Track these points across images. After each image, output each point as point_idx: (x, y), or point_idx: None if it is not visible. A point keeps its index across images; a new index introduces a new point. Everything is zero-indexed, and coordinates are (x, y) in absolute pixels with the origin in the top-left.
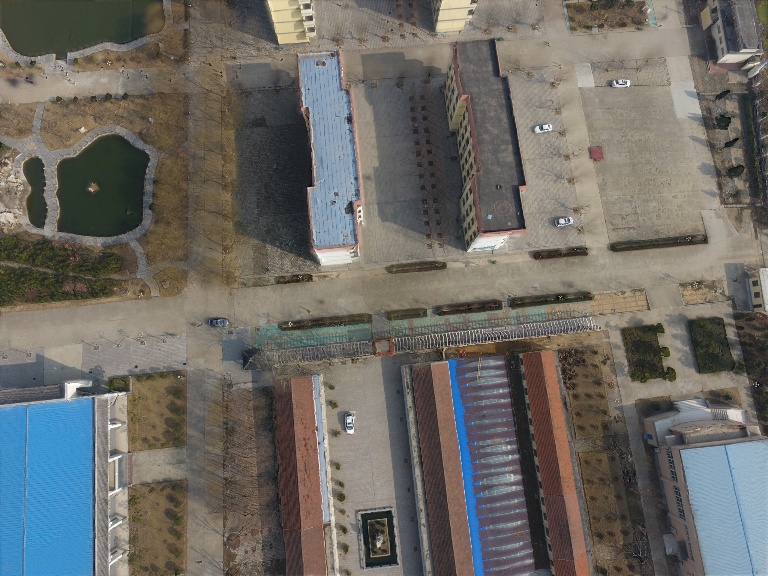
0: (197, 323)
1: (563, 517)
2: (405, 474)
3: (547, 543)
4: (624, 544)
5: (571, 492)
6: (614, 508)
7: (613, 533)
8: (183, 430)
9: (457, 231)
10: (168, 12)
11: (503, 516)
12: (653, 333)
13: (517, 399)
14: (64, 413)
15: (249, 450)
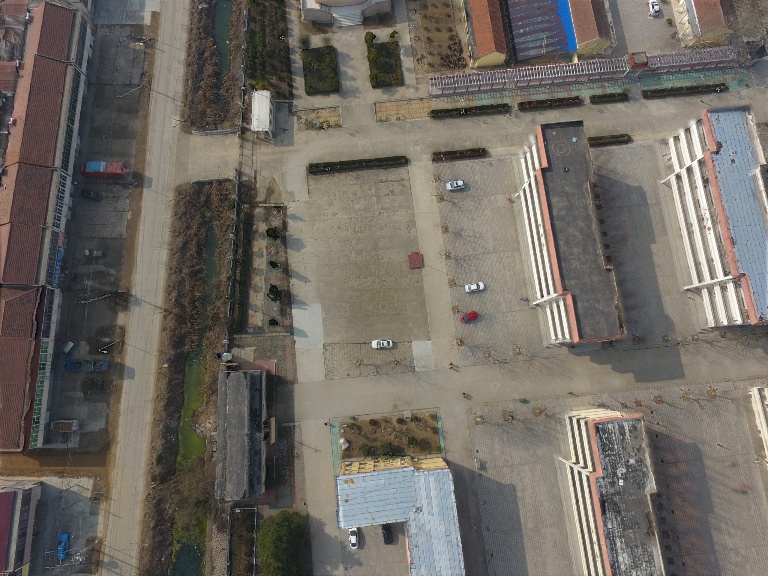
0: None
1: None
2: None
3: None
4: None
5: None
6: None
7: None
8: None
9: None
10: None
11: None
12: None
13: (504, 28)
14: None
15: None
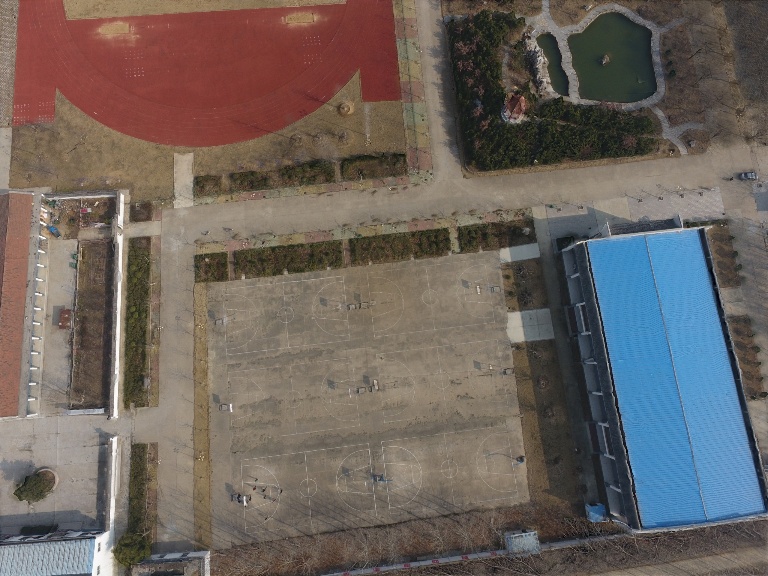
0: (727, 178)
1: None
2: None
3: None
4: None
5: None
6: None
7: None
8: (737, 272)
9: None
10: None
11: None
12: None
13: None
14: (682, 241)
15: None
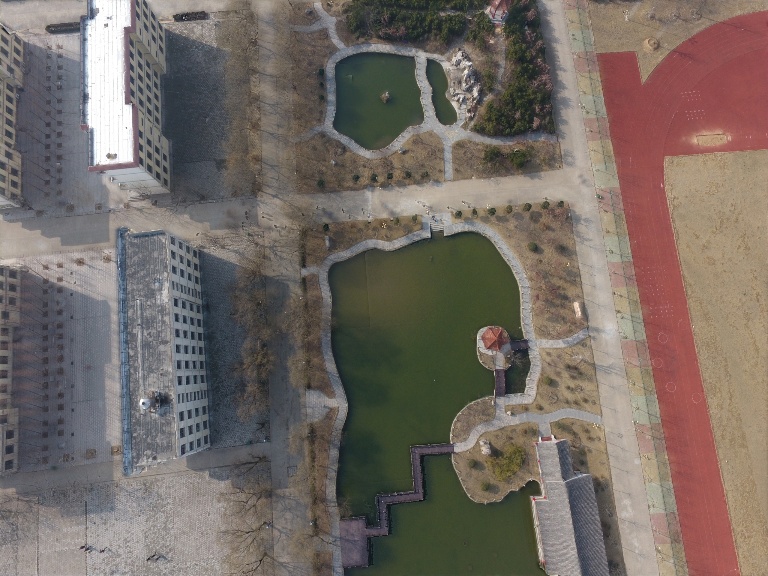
0: None
1: None
2: None
3: None
4: None
5: None
6: None
7: None
8: None
9: (31, 60)
10: (325, 289)
11: None
12: None
13: None
14: None
15: None
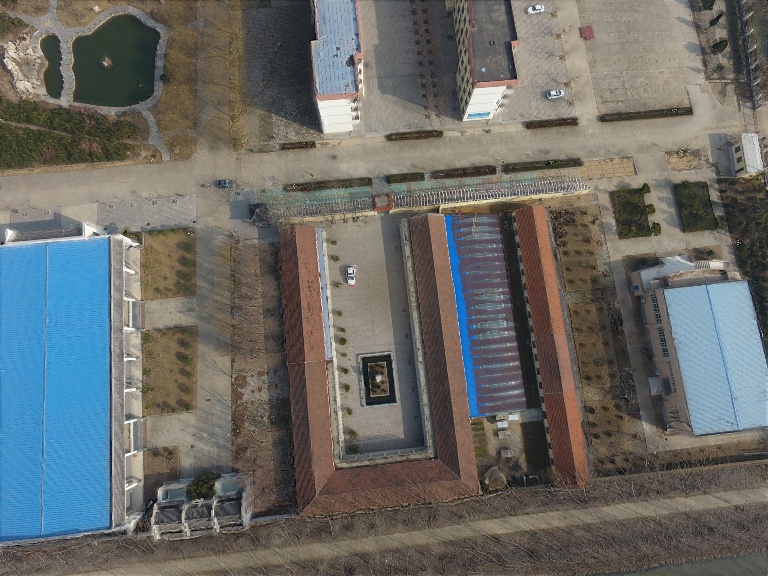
0: (206, 185)
1: (553, 354)
2: (403, 322)
3: (538, 381)
4: (611, 386)
5: (560, 333)
6: (602, 354)
7: (601, 376)
8: (193, 281)
9: (453, 103)
10: None
11: (496, 357)
12: (640, 195)
13: (510, 255)
14: (82, 250)
15: (255, 300)
